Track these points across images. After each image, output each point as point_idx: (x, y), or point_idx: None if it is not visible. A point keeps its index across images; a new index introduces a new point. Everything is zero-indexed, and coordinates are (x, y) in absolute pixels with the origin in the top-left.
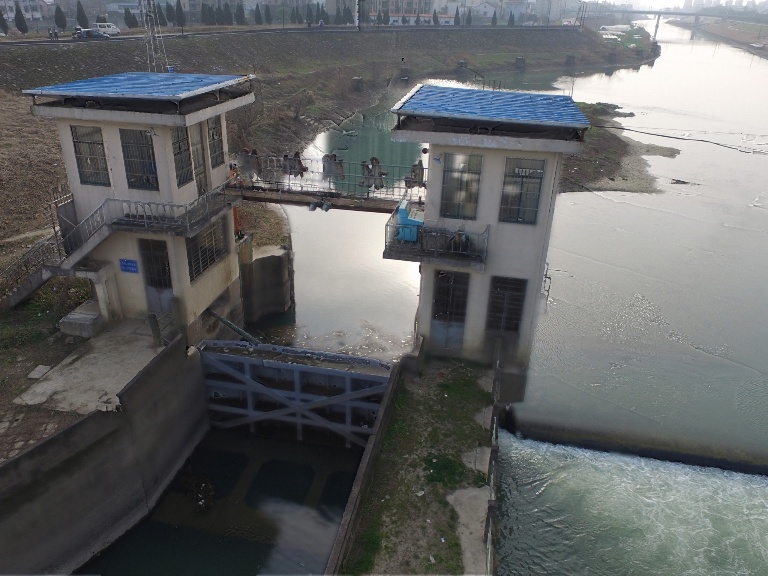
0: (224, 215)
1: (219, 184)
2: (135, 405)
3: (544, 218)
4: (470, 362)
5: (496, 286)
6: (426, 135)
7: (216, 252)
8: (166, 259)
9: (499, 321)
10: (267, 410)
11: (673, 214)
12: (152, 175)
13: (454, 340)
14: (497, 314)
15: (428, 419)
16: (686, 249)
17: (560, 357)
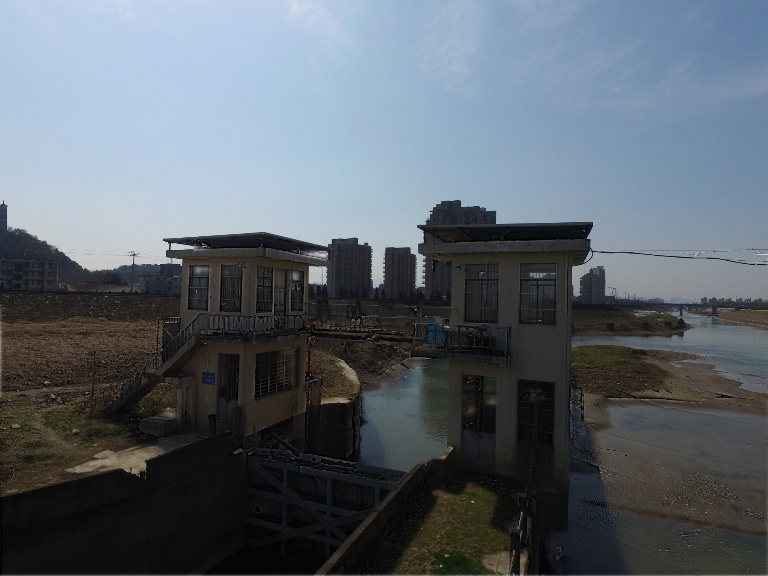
0: (297, 353)
1: (295, 325)
2: (161, 478)
3: (562, 317)
4: (504, 479)
5: (524, 392)
6: (447, 245)
7: (285, 382)
8: (237, 372)
9: (530, 431)
10: (299, 527)
11: (723, 418)
12: (238, 299)
13: (486, 454)
14: (528, 423)
15: (448, 519)
16: (744, 443)
17: (618, 519)
